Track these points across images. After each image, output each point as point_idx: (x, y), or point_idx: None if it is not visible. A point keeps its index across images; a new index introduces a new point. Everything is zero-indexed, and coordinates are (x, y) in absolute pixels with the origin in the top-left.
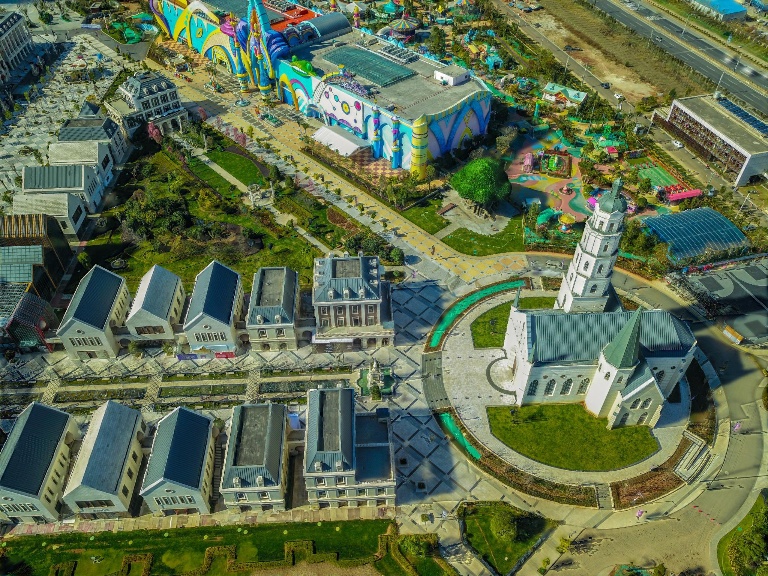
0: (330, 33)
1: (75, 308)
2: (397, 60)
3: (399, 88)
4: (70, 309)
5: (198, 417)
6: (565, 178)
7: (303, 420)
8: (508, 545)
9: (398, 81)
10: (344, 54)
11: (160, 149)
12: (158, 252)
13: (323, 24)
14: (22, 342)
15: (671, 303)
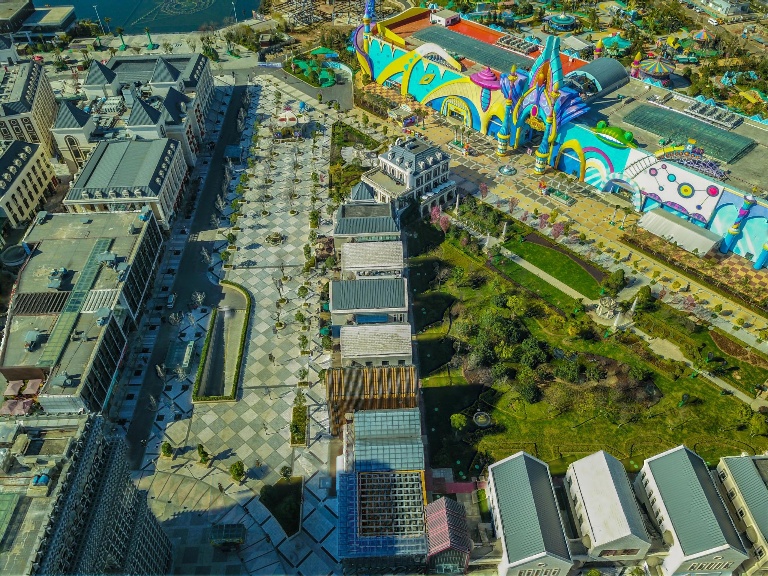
0: (610, 85)
1: (536, 532)
2: (718, 124)
3: (750, 165)
4: (512, 524)
5: None
6: None
7: None
8: None
9: (741, 154)
10: (650, 116)
11: (443, 238)
12: (530, 402)
13: (602, 75)
14: (438, 566)
15: None
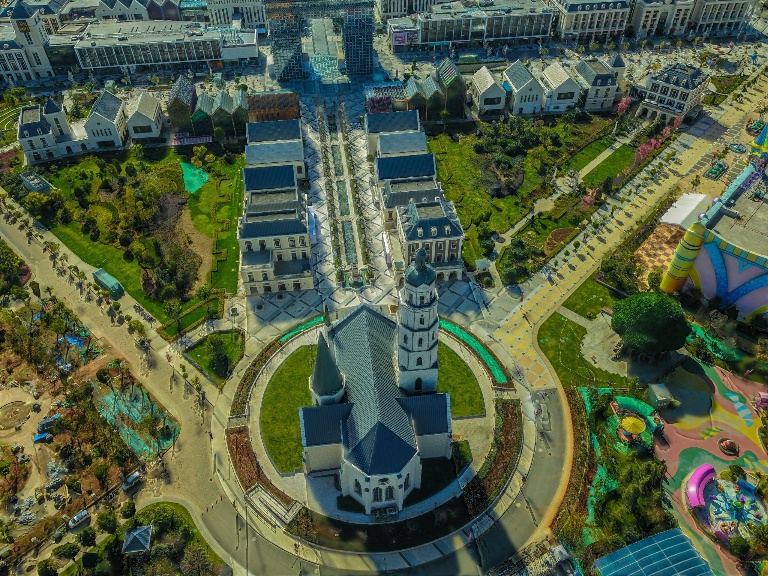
0: None
1: None
2: None
3: None
4: None
5: (293, 178)
6: (765, 449)
7: (318, 245)
8: (208, 357)
9: None
10: None
11: None
12: None
13: None
14: None
15: (510, 545)
